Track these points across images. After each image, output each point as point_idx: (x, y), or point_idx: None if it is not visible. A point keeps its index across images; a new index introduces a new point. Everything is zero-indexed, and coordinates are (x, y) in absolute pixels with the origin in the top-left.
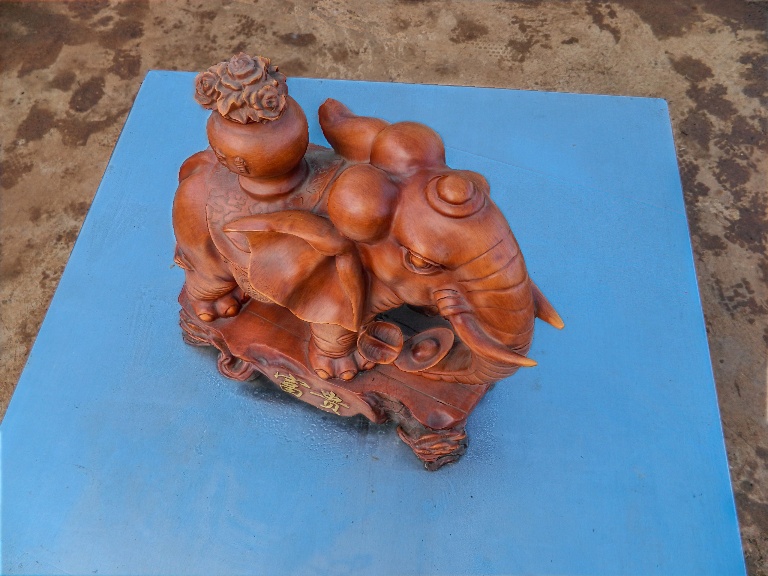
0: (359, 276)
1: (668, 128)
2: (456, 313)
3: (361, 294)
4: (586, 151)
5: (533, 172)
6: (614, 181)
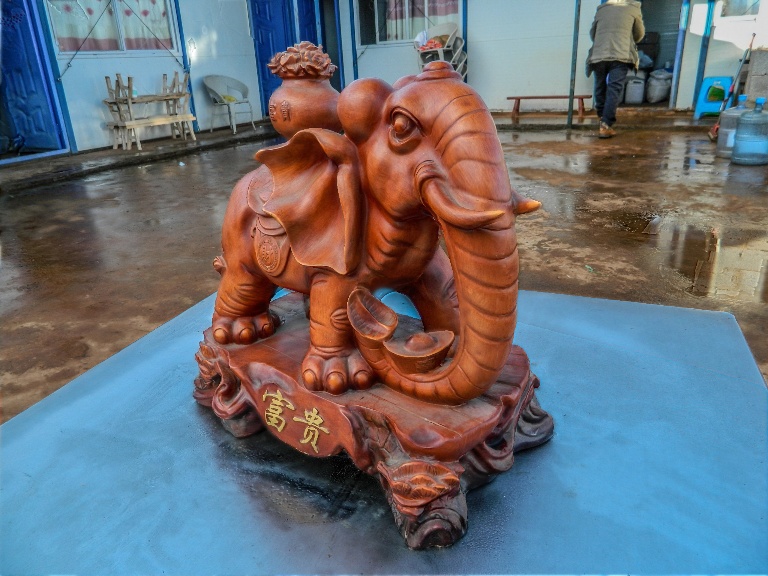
0: (356, 191)
1: (737, 329)
2: (430, 176)
3: (355, 214)
4: (644, 333)
5: (586, 340)
6: (676, 353)
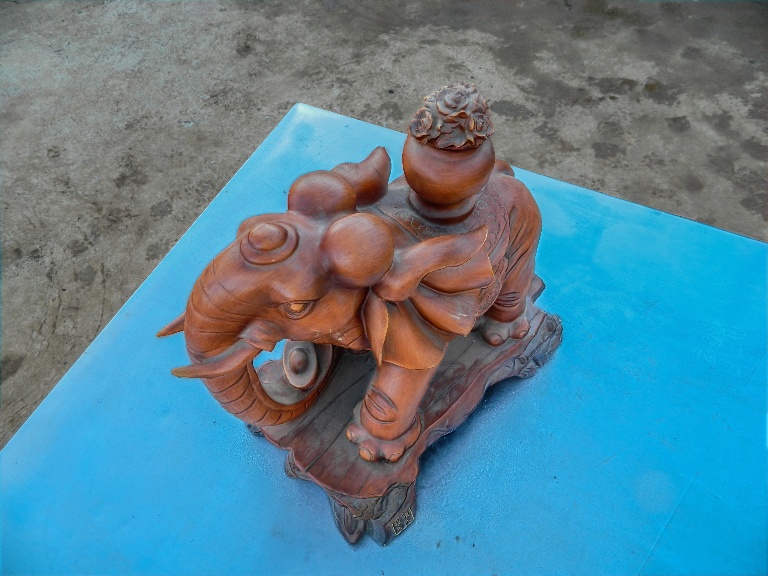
0: None
1: None
2: None
3: None
4: None
5: None
6: None
